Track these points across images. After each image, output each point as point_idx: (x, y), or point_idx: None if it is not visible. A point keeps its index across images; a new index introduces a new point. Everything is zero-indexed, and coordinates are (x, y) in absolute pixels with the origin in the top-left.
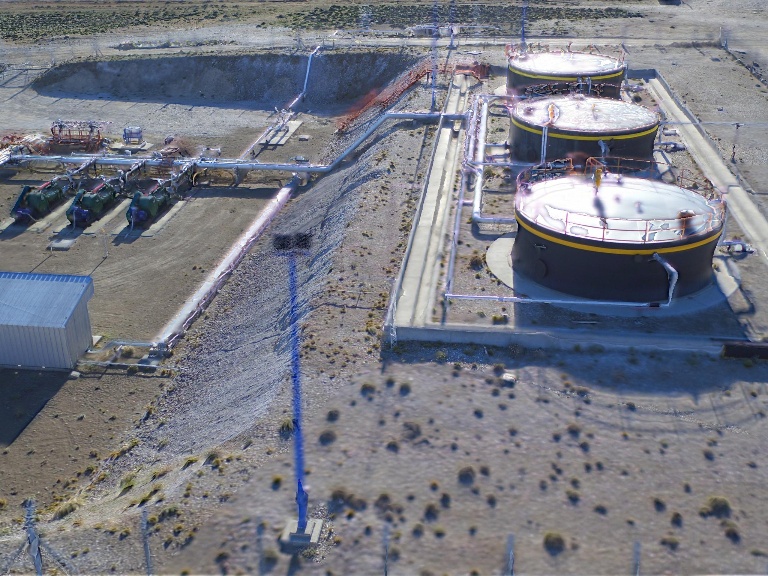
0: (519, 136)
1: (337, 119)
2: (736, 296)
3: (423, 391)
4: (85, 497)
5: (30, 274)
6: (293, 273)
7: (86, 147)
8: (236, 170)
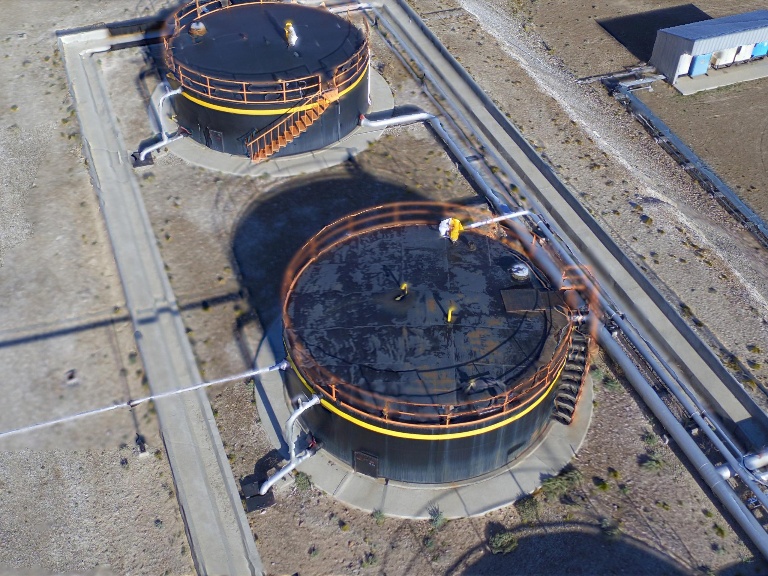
0: None
1: None
2: (155, 84)
3: None
4: (509, 4)
5: (742, 31)
6: None
7: None
8: None
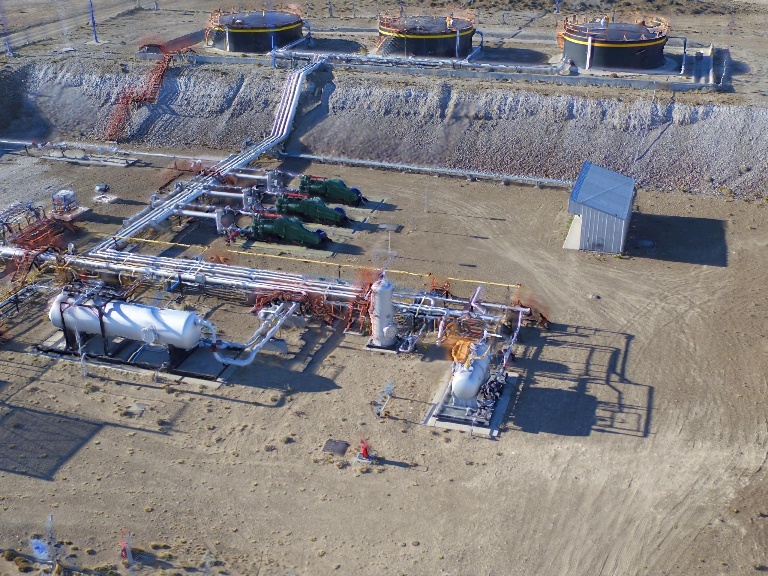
0: (434, 44)
1: (61, 141)
2: None
3: (760, 89)
4: None
5: (580, 175)
6: (561, 130)
7: (64, 229)
8: (248, 164)
